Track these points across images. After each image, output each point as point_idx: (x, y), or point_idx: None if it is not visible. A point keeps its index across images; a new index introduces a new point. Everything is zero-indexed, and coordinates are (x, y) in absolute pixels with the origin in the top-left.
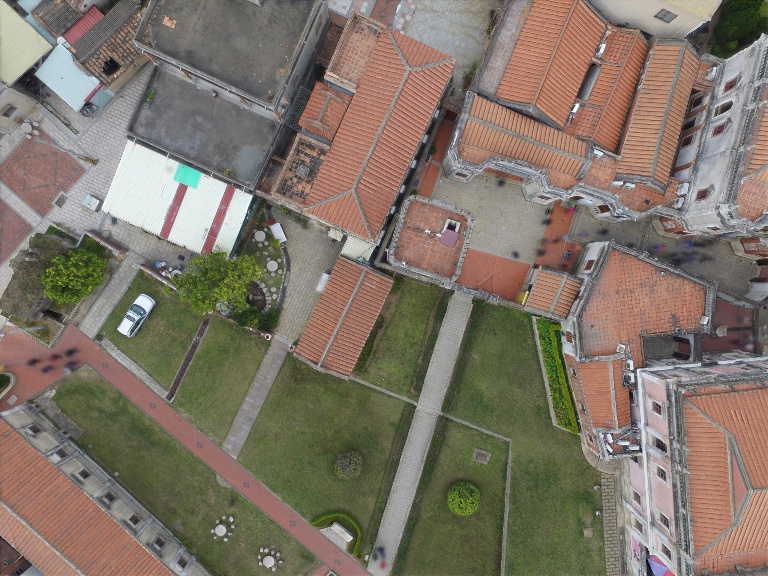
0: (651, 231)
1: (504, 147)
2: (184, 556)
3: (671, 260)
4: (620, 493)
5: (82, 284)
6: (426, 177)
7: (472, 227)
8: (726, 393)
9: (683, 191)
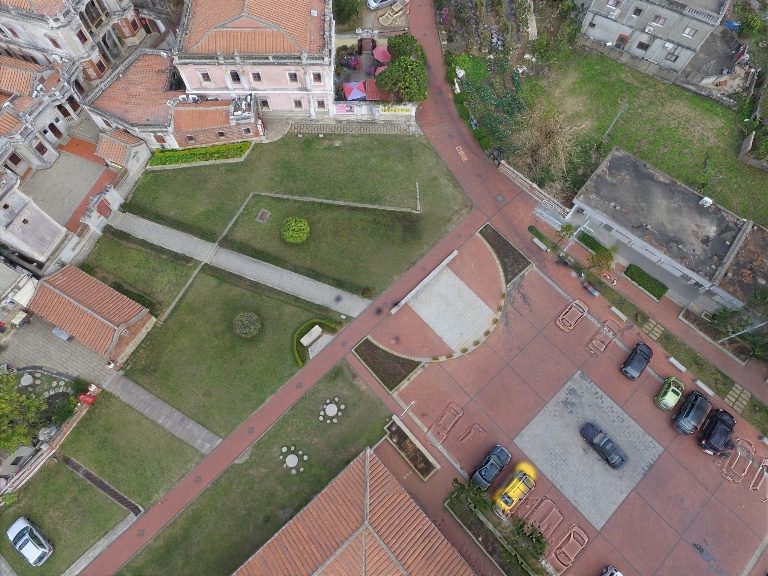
0: None
1: None
2: None
3: None
4: (307, 121)
5: None
6: None
7: None
8: None
9: (57, 58)
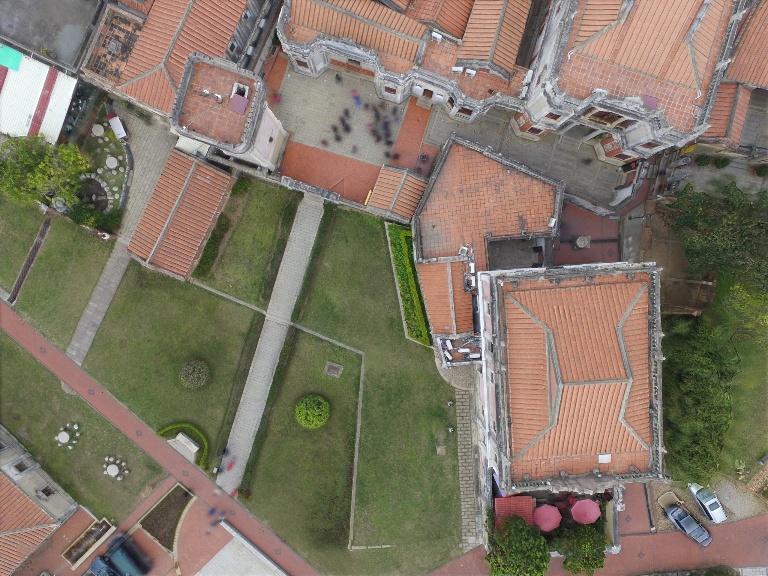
0: (510, 133)
1: (335, 27)
2: (26, 462)
3: (531, 165)
4: (475, 410)
5: None
6: (273, 70)
7: (257, 89)
8: (552, 289)
9: (526, 79)
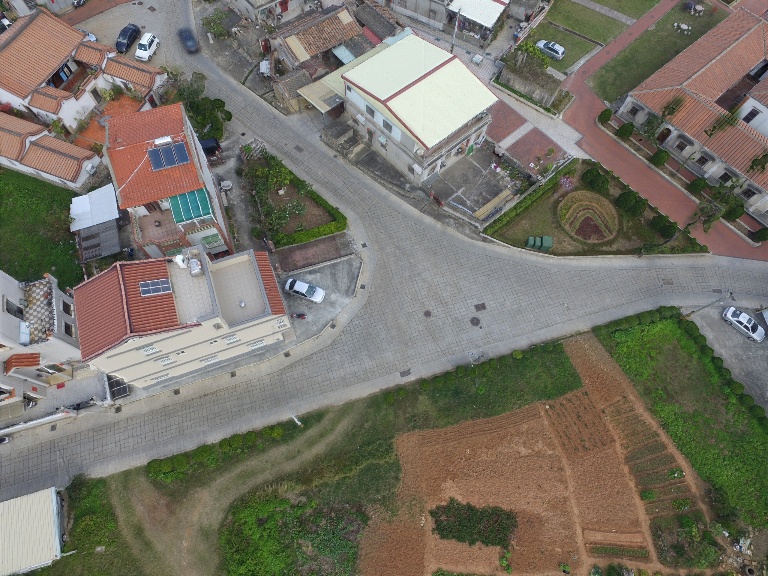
0: None
1: None
2: None
3: None
4: None
5: None
6: None
7: None
8: None
9: None
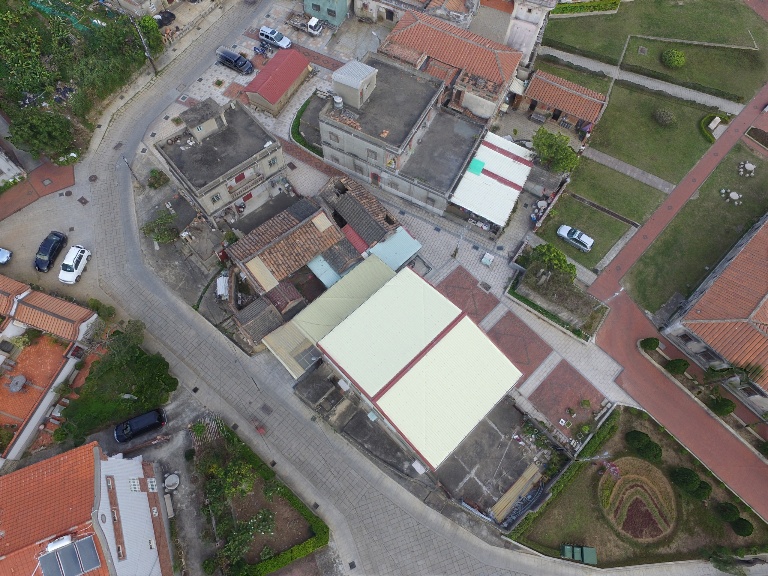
0: None
1: None
2: None
3: None
4: None
5: None
6: None
7: None
8: None
9: None
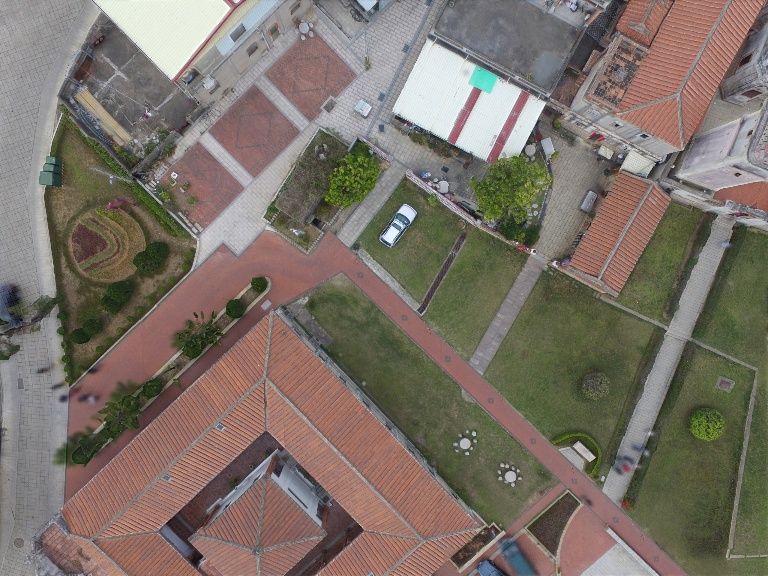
0: None
1: None
2: (429, 467)
3: None
4: None
5: (360, 187)
6: None
7: None
8: None
9: None
